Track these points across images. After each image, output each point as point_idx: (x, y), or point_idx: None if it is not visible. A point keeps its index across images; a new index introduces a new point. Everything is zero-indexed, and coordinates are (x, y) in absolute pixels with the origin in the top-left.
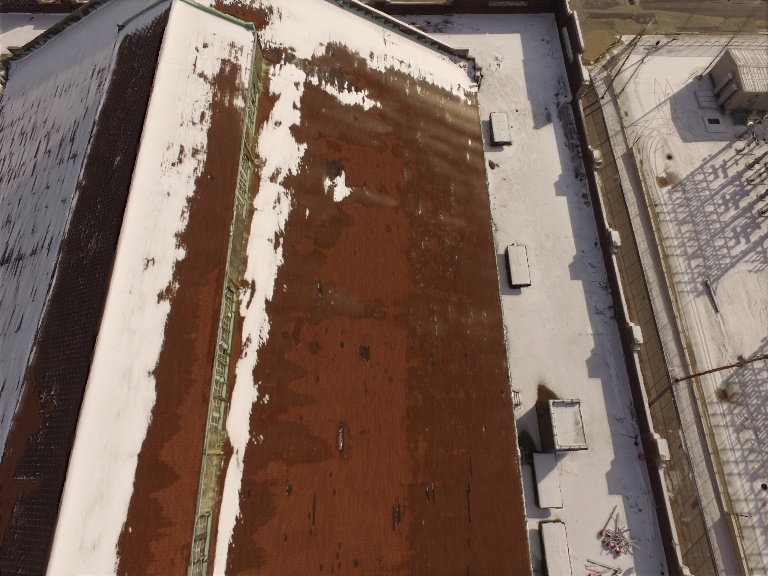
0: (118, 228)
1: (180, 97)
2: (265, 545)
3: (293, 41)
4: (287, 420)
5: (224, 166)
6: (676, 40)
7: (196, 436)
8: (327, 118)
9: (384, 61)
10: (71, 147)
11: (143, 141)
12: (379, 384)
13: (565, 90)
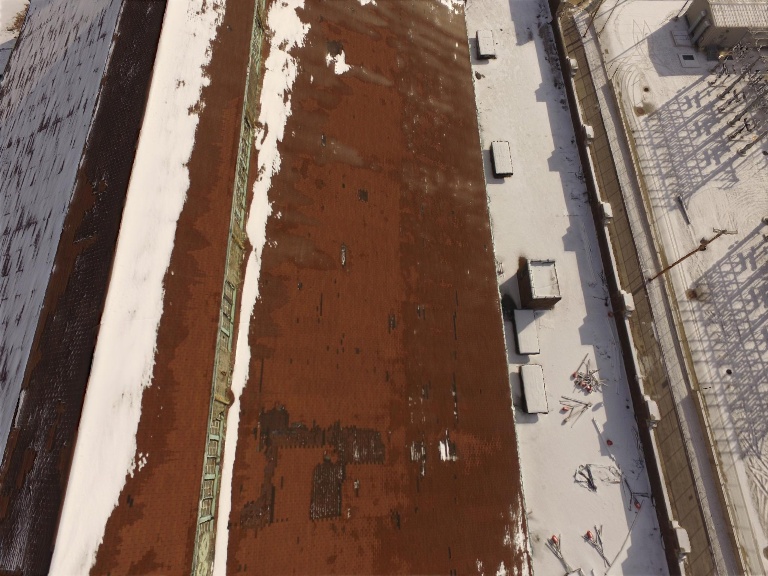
0: (154, 54)
1: None
2: (281, 323)
3: None
4: (297, 234)
5: (240, 21)
6: None
7: (223, 217)
8: (328, 6)
9: None
10: (100, 29)
11: None
12: (376, 221)
13: (546, 12)
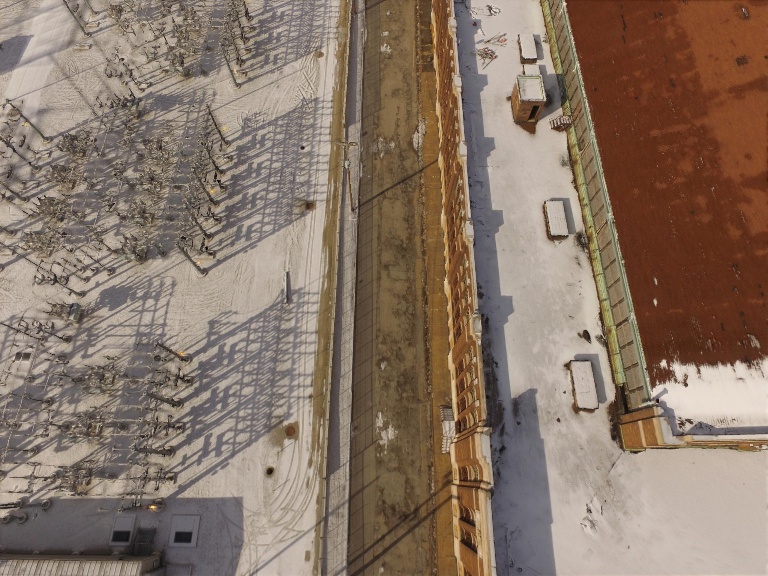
0: None
1: None
2: None
3: None
4: None
5: None
6: None
7: None
8: None
9: None
10: None
11: None
12: (721, 49)
13: None
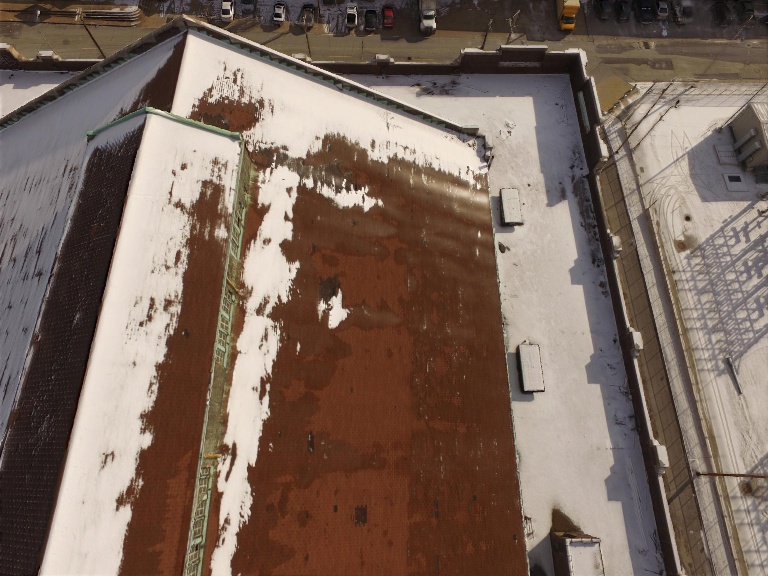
0: (72, 417)
1: (152, 236)
2: None
3: (286, 138)
4: None
5: (201, 316)
6: (694, 88)
7: None
8: (322, 227)
9: (386, 149)
10: (37, 261)
11: (106, 300)
12: (377, 552)
13: (581, 162)
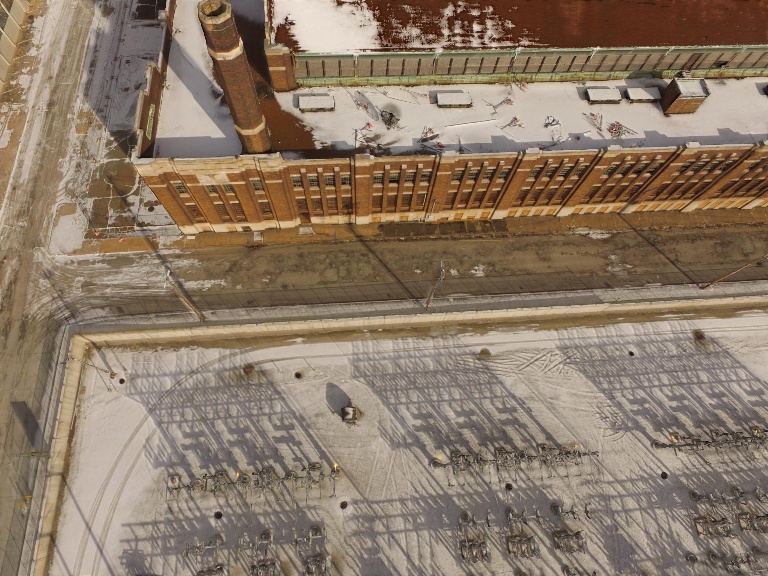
0: None
1: None
2: None
3: None
4: None
5: None
6: None
7: None
8: None
9: None
10: None
11: None
12: None
13: None
